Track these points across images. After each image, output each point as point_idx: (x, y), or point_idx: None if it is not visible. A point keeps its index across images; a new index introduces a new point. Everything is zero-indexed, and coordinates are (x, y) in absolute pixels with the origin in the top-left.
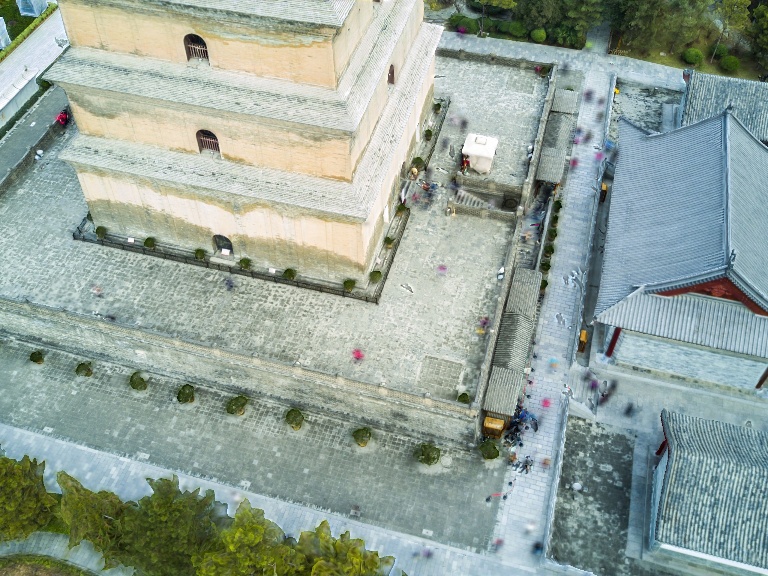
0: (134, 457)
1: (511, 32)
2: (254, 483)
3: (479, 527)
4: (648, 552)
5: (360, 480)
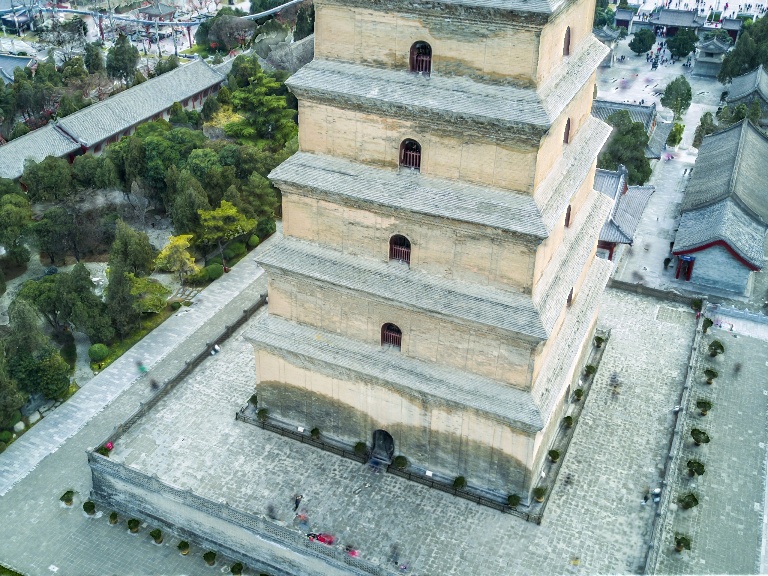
0: (761, 513)
1: (239, 253)
2: (760, 440)
3: (756, 343)
4: (745, 294)
5: (739, 388)
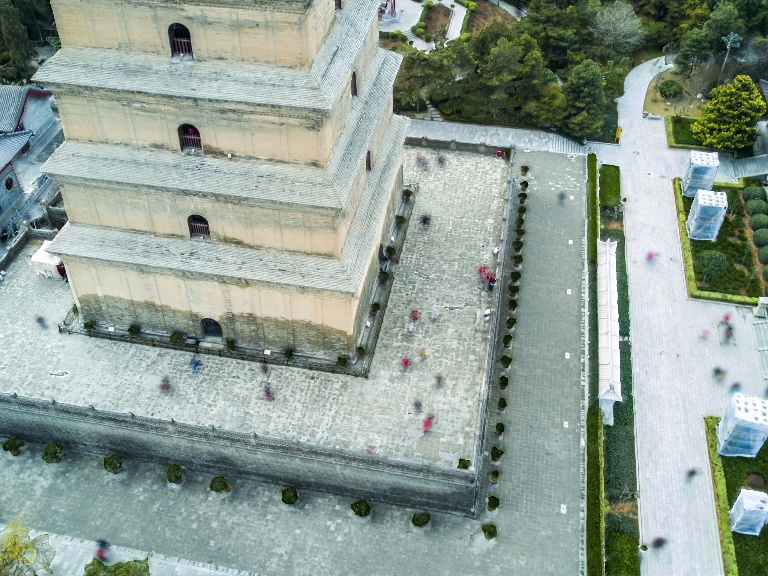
0: None
1: None
2: None
3: None
4: (57, 120)
5: None
